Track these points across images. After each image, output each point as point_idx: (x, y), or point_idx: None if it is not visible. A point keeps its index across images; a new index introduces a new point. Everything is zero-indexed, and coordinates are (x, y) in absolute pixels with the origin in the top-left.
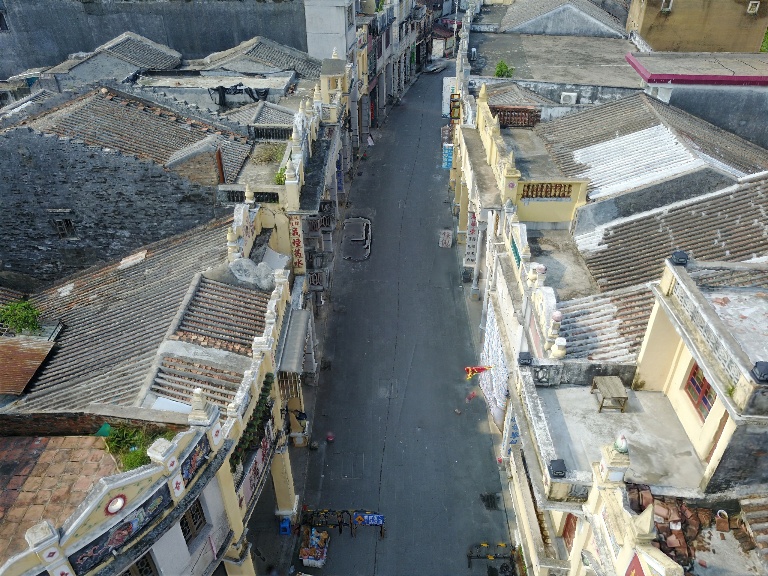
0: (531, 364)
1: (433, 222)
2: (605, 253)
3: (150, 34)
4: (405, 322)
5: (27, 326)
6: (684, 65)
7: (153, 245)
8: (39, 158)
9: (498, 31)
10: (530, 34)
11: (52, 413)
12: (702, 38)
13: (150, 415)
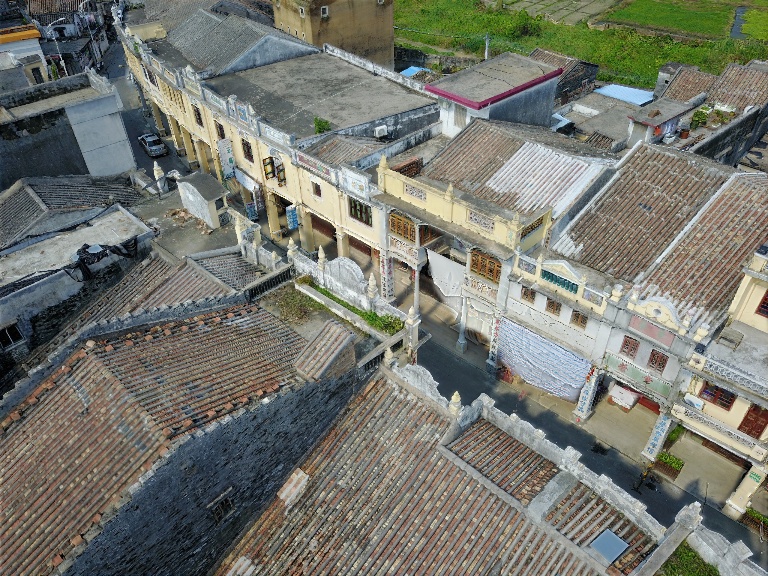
0: None
1: None
2: (588, 251)
3: None
4: None
5: None
6: (471, 84)
7: (302, 459)
8: (202, 459)
9: (212, 76)
10: (243, 70)
11: None
12: (356, 32)
13: (669, 548)
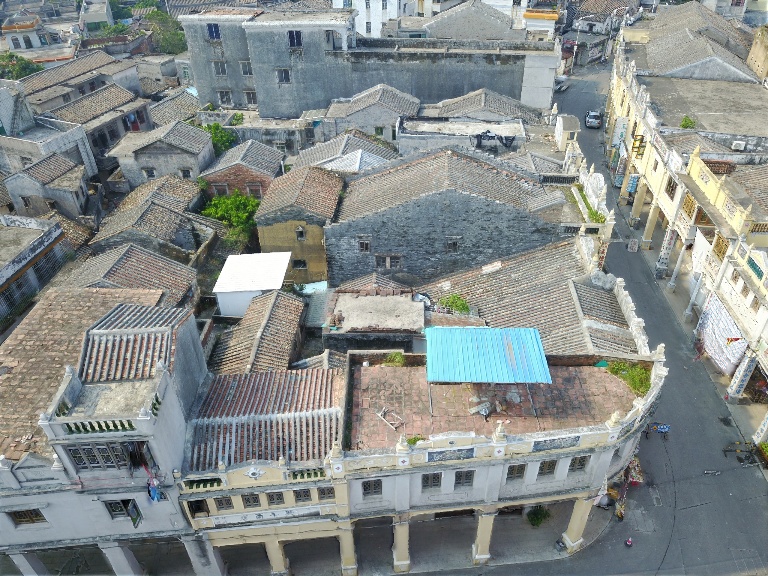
0: None
1: None
2: None
3: (399, 86)
4: None
5: (464, 309)
6: None
7: (505, 258)
8: (454, 206)
9: (652, 75)
10: (679, 78)
11: (579, 355)
12: None
13: (630, 356)
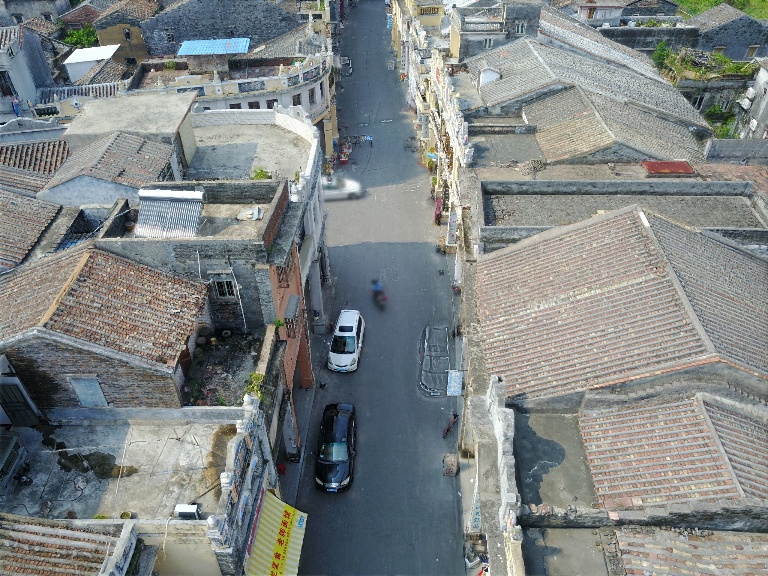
0: (418, 49)
1: (384, 61)
2: None
3: None
4: (373, 95)
5: None
6: None
7: (268, 42)
8: (225, 2)
9: None
10: None
11: (280, 57)
12: None
13: None
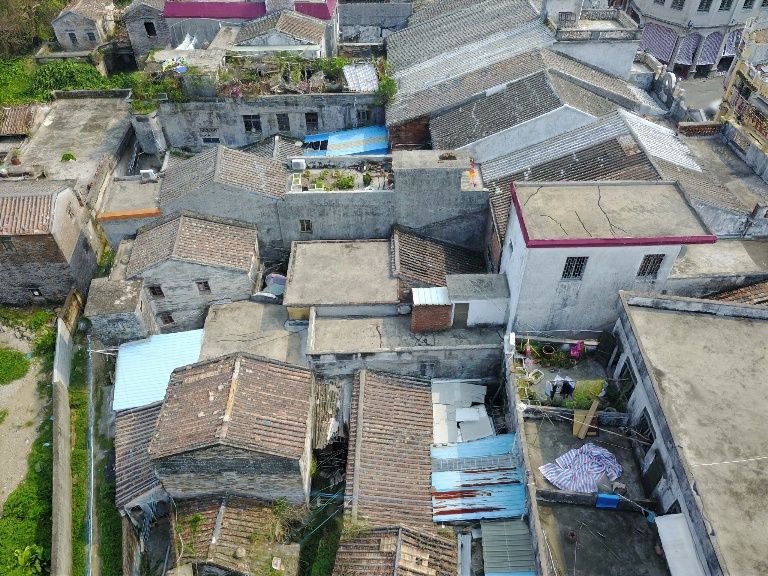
0: None
1: None
2: None
3: None
4: None
5: None
6: (648, 217)
7: None
8: None
9: None
10: None
11: None
12: None
13: (766, 43)
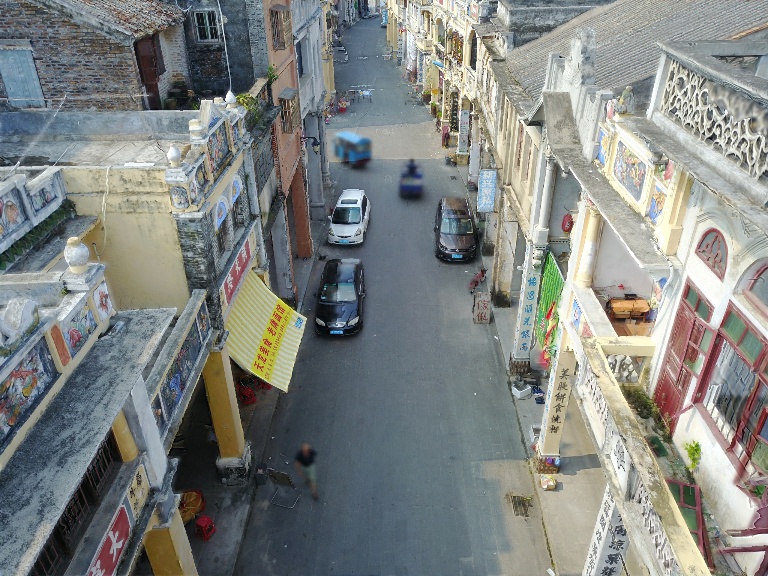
0: None
1: (379, 55)
2: None
3: None
4: (370, 74)
5: None
6: None
7: None
8: None
9: None
10: None
11: None
12: None
13: None
